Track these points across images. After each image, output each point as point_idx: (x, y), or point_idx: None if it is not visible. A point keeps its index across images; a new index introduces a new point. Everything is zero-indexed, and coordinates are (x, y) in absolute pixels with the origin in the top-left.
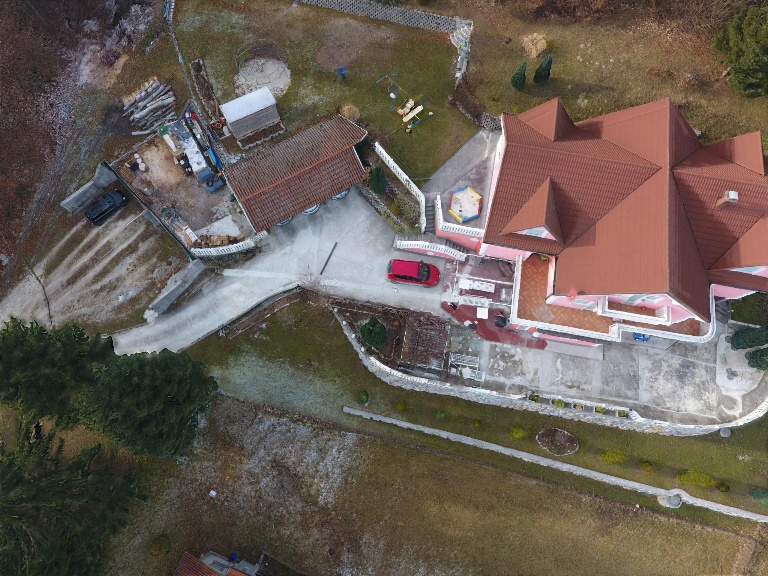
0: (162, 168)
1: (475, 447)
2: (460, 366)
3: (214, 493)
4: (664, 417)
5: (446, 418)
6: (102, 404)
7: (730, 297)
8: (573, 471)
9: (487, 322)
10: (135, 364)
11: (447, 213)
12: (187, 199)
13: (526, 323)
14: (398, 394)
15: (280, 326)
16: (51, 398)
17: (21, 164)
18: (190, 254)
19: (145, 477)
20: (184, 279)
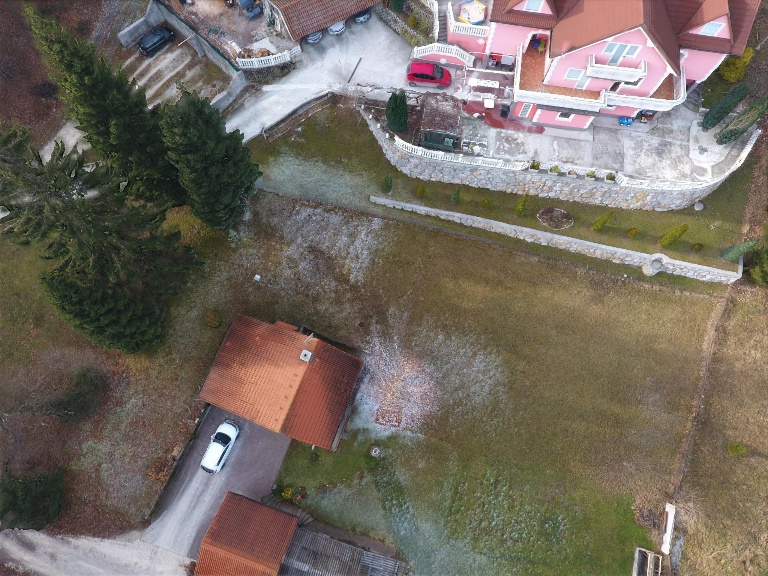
0: (206, 2)
1: (484, 230)
2: (471, 145)
3: (258, 277)
4: None
5: (459, 203)
6: (182, 121)
7: (699, 78)
8: (569, 247)
9: (493, 114)
10: (205, 101)
11: (457, 20)
12: (229, 26)
13: (527, 94)
14: (417, 185)
15: (314, 128)
16: (130, 149)
17: (81, 4)
18: (234, 67)
19: (199, 259)
20: (229, 90)
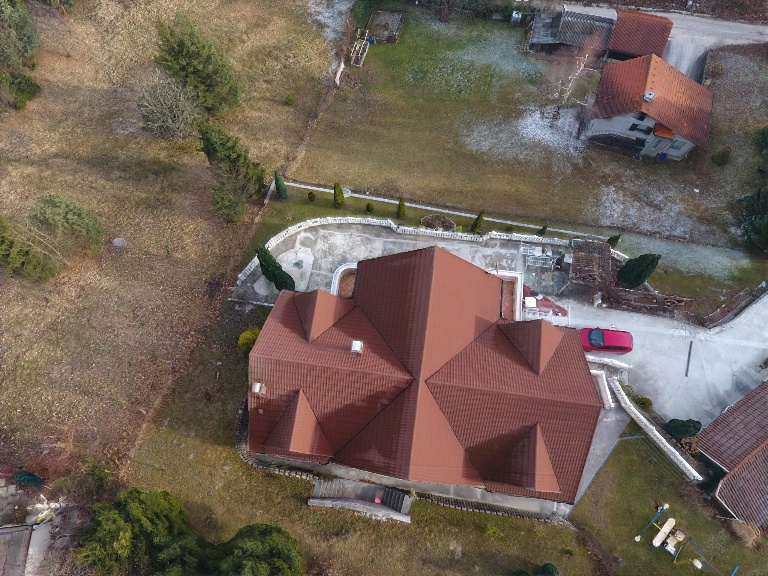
0: None
1: None
2: None
3: (696, 191)
4: (364, 229)
5: None
6: None
7: None
8: None
9: None
10: None
11: None
12: None
13: (508, 274)
14: None
15: (708, 298)
16: None
17: None
18: None
19: None
20: None
